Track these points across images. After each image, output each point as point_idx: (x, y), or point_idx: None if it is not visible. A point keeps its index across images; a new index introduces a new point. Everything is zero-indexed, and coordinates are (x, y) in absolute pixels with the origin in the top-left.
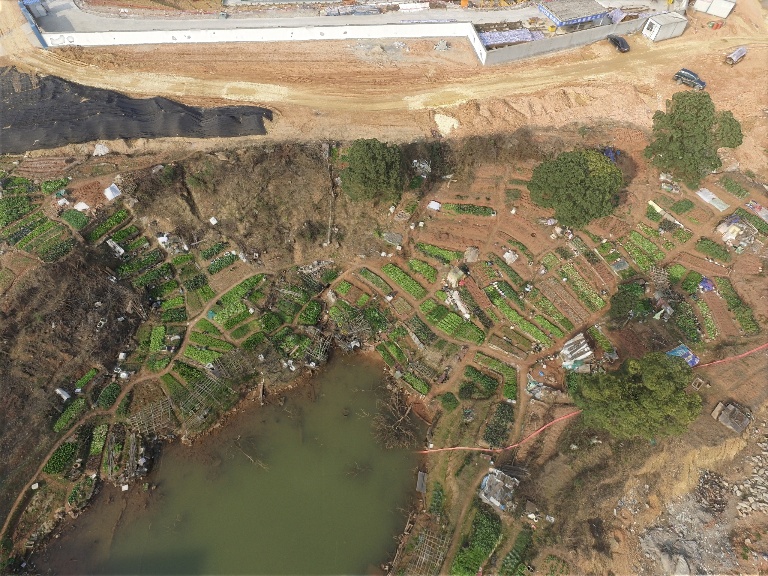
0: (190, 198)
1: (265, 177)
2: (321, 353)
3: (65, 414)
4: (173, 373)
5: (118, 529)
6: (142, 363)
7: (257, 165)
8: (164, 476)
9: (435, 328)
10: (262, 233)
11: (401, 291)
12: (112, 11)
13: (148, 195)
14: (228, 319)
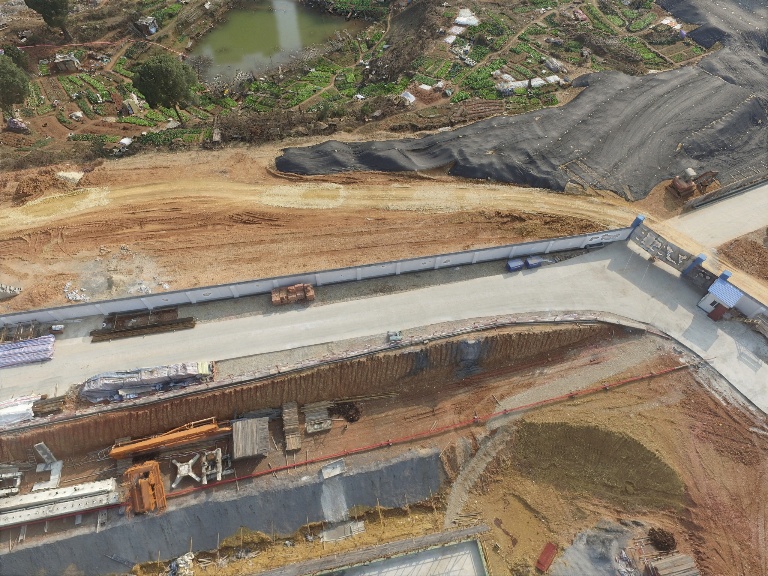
0: None
1: None
2: (240, 73)
3: None
4: None
5: None
6: None
7: None
8: None
9: None
10: None
11: None
12: (620, 355)
13: None
14: None
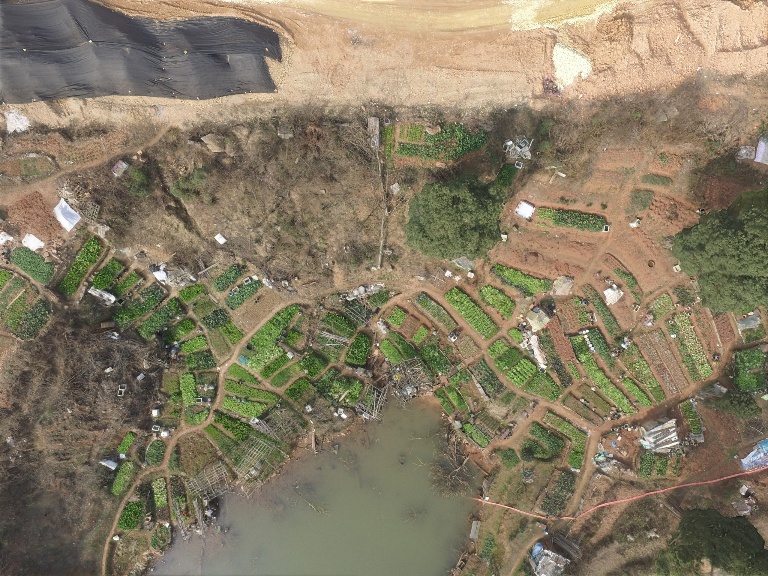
0: (180, 207)
1: (285, 182)
2: (376, 411)
3: (118, 478)
4: (216, 424)
5: (204, 562)
6: (179, 417)
7: (270, 161)
8: (233, 518)
9: (504, 377)
10: (289, 255)
11: (468, 327)
12: None
13: (120, 216)
14: (264, 366)
